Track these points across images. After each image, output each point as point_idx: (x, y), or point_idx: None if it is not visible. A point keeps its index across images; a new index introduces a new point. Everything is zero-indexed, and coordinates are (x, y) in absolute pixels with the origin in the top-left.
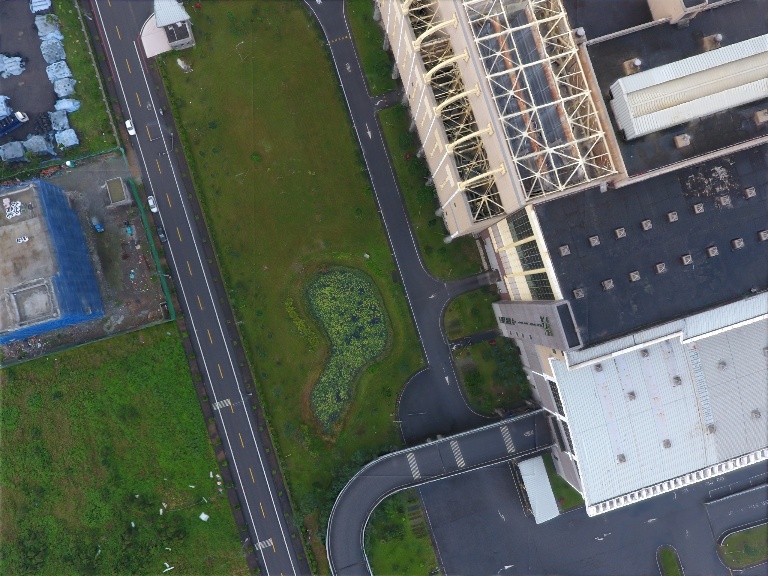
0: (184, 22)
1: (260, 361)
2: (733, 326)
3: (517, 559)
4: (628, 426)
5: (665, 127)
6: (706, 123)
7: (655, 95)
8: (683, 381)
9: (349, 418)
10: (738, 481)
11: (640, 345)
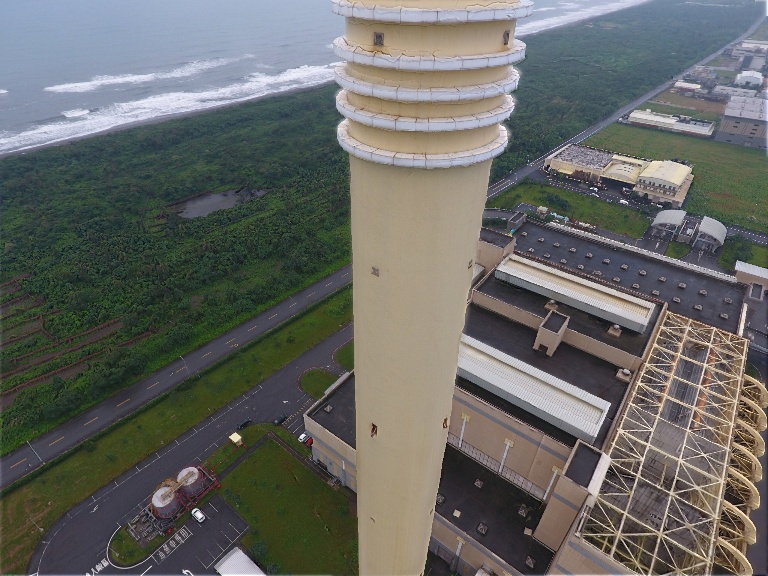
0: None
1: None
2: None
3: (767, 311)
4: None
5: None
6: None
7: (624, 308)
8: None
9: None
10: None
11: None
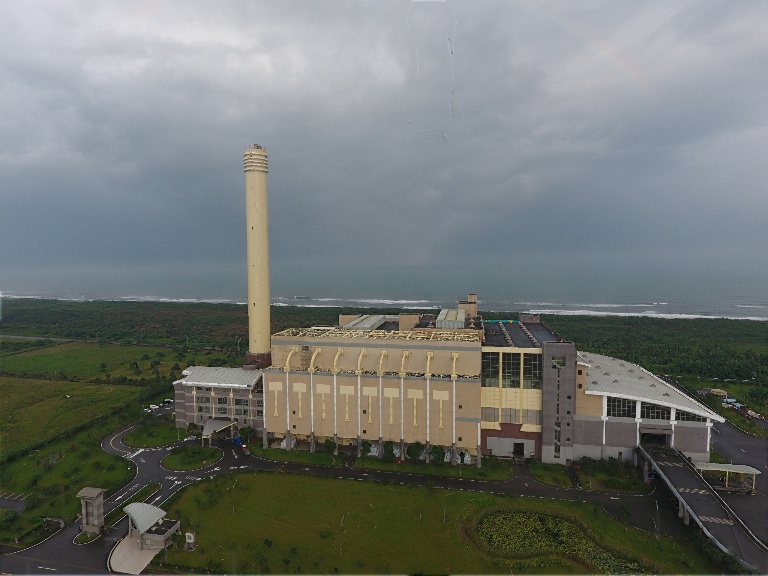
0: (162, 519)
1: None
2: None
3: None
4: None
5: None
6: (467, 325)
7: None
8: None
9: (665, 568)
10: None
11: None
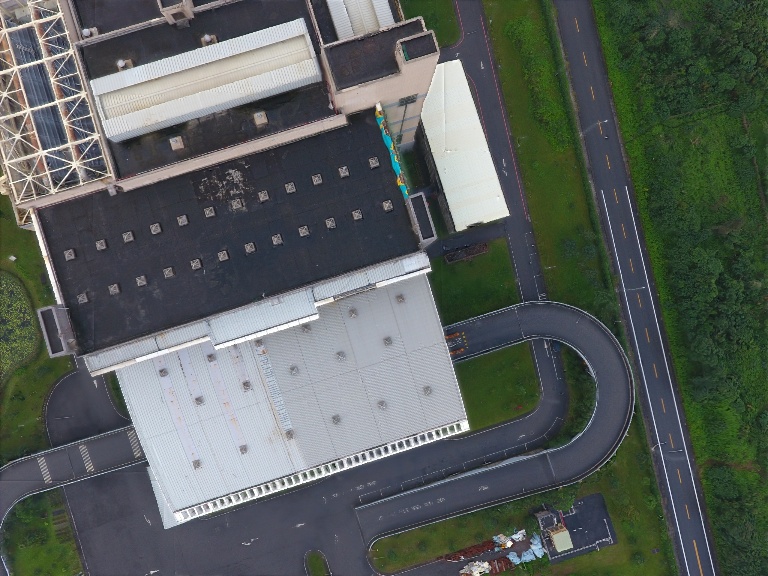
0: None
1: None
2: (267, 331)
3: (163, 564)
4: (200, 432)
5: (151, 129)
6: (205, 125)
7: (131, 97)
8: (254, 386)
9: None
10: (389, 486)
11: (165, 350)
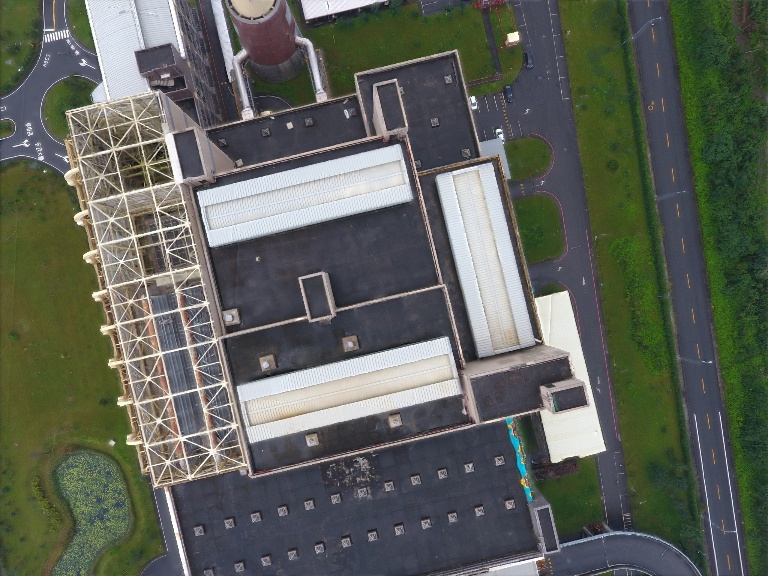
0: None
1: (6, 535)
2: None
3: None
4: None
5: None
6: (340, 422)
7: (275, 403)
8: None
9: None
10: None
11: None
